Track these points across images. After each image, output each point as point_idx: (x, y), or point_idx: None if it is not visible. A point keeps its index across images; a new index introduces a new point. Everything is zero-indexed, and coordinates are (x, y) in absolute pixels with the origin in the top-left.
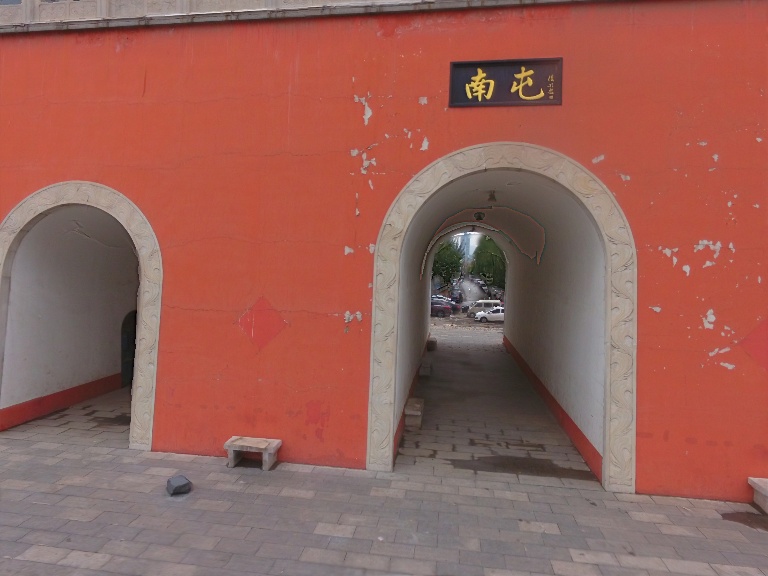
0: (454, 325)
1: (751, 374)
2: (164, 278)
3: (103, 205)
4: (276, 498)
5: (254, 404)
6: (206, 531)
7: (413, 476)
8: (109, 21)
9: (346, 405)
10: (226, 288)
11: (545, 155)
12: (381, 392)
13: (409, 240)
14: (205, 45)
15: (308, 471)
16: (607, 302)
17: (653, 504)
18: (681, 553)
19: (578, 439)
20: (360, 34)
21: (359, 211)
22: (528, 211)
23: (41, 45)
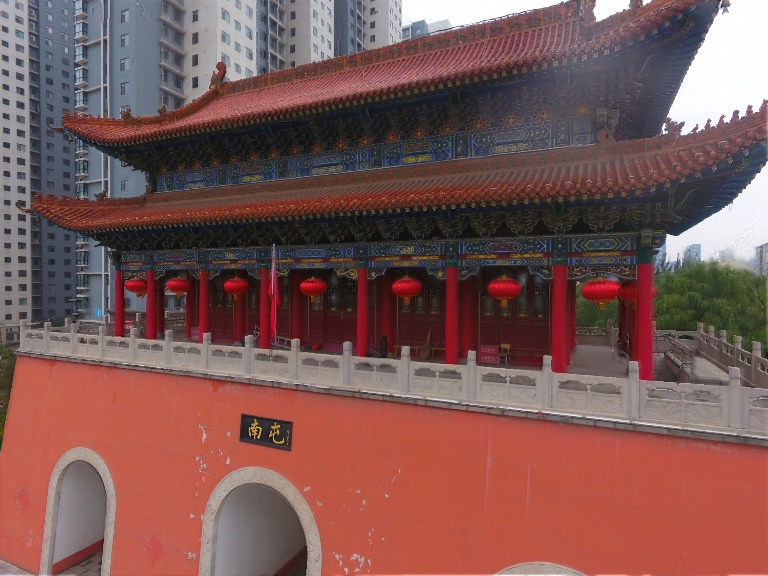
0: None
1: None
2: (116, 512)
3: (94, 464)
4: None
5: None
6: None
7: None
8: (101, 362)
9: None
10: (141, 524)
11: (282, 480)
12: None
13: (240, 499)
14: (139, 381)
15: None
16: None
17: None
18: None
19: None
20: (203, 388)
21: (198, 494)
22: None
23: (75, 369)
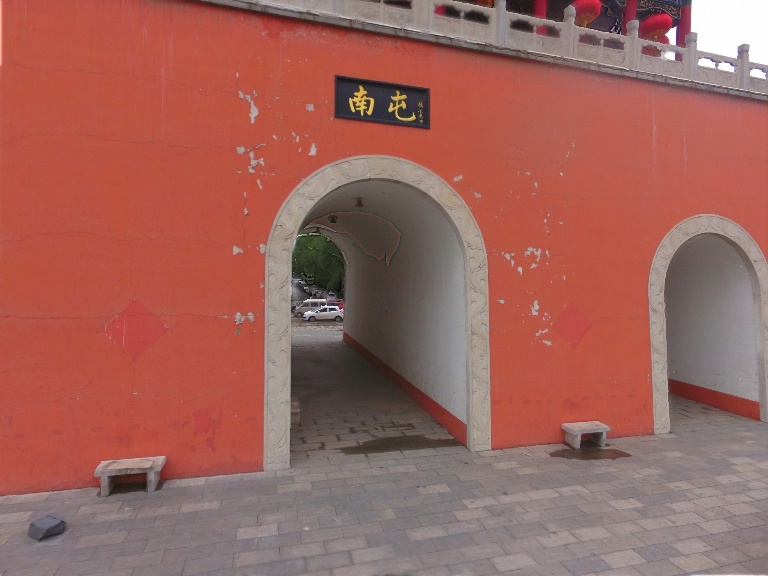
0: None
1: (561, 347)
2: None
3: None
4: (178, 516)
5: (128, 421)
6: (109, 566)
7: (312, 469)
8: None
9: (240, 409)
10: (85, 291)
11: (418, 171)
12: (277, 392)
13: None
14: (45, 1)
15: (201, 483)
16: (468, 297)
17: (505, 455)
18: (534, 486)
19: (440, 414)
20: (243, 30)
21: (248, 210)
22: (390, 217)
23: None
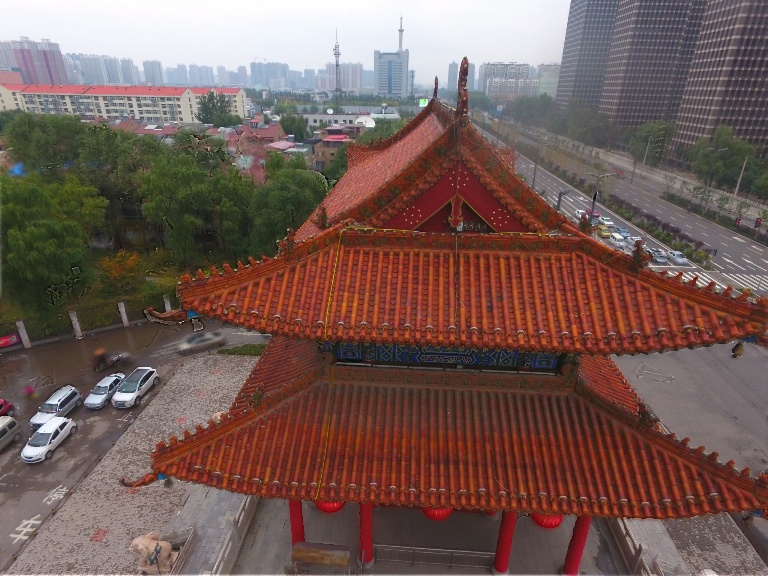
0: (61, 491)
1: None
2: None
3: None
4: None
5: None
6: None
7: None
8: None
9: None
10: None
11: None
12: None
13: None
14: None
15: None
16: None
17: None
18: None
19: None
20: None
21: None
22: None
23: None
